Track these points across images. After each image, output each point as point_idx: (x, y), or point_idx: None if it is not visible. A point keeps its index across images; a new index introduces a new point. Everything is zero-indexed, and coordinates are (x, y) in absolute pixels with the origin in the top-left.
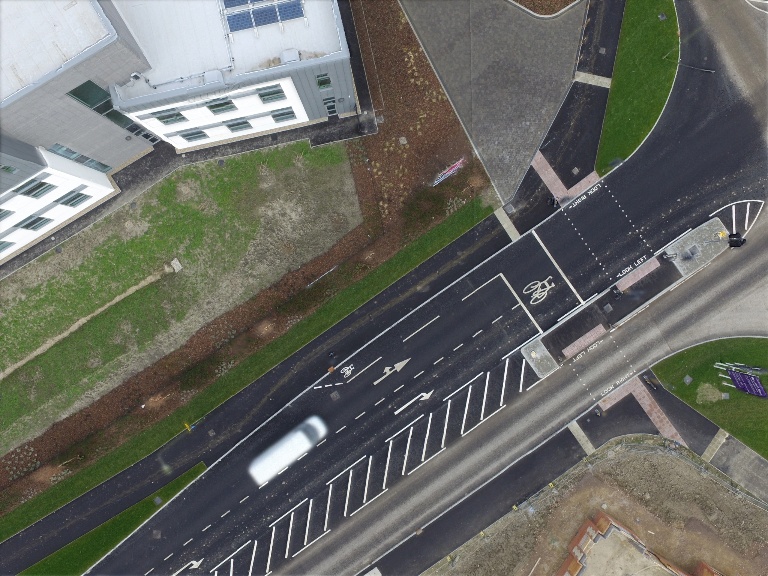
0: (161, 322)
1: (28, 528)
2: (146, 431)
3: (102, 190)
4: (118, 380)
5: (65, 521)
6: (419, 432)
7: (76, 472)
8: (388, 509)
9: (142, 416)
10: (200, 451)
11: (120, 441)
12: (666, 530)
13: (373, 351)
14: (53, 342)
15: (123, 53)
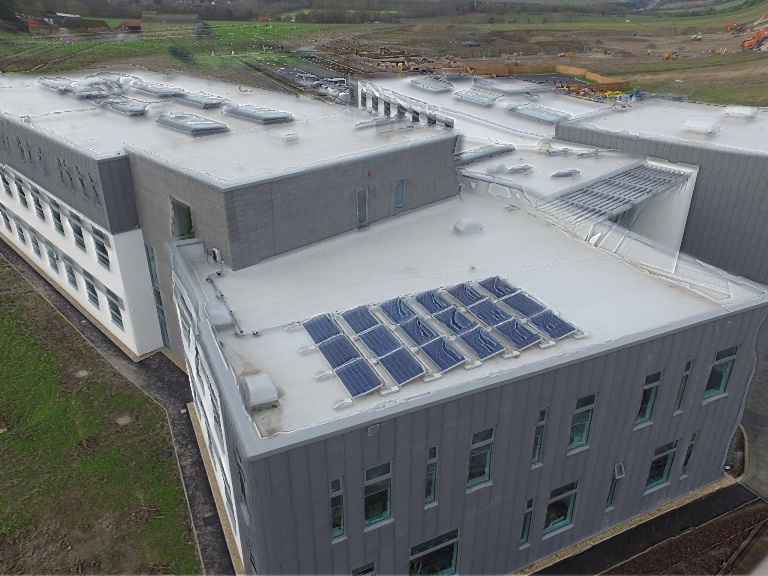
0: None
1: None
2: None
3: None
4: None
5: None
6: None
7: None
8: None
9: None
10: None
11: None
12: None
13: None
14: None
15: (223, 215)
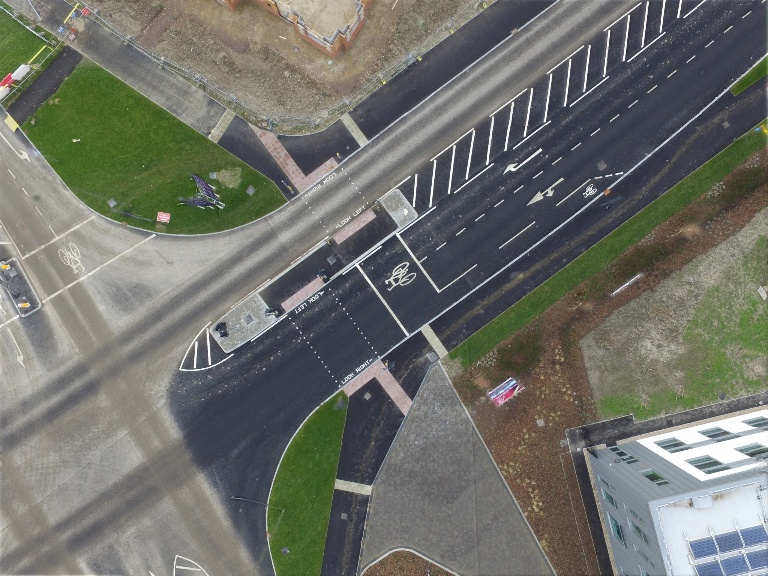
0: None
1: None
2: None
3: None
4: None
5: None
6: (517, 132)
7: None
8: (546, 54)
9: None
10: (737, 106)
11: None
12: (268, 41)
13: (565, 211)
14: None
15: None
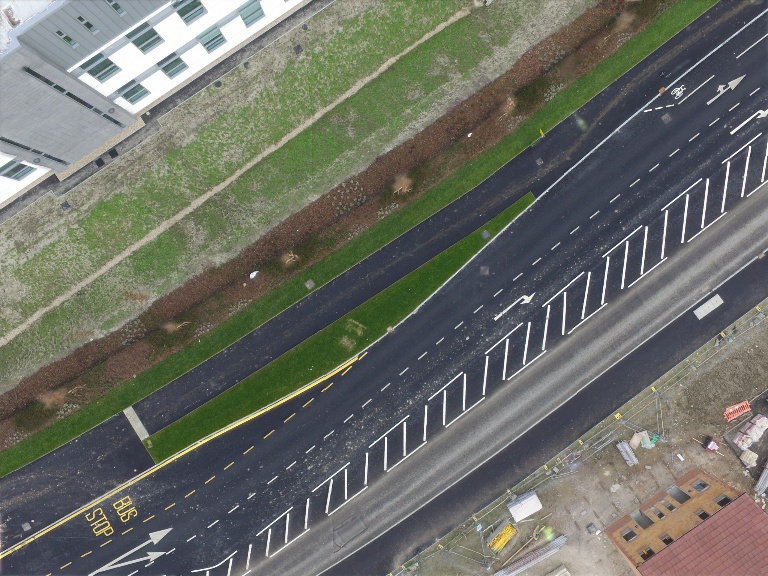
0: (481, 50)
1: (355, 266)
2: (472, 162)
3: None
4: (442, 110)
5: (392, 258)
6: (758, 151)
7: (402, 207)
8: (727, 234)
9: (471, 143)
10: (528, 181)
11: (446, 173)
12: None
13: (705, 70)
14: (362, 84)
15: None
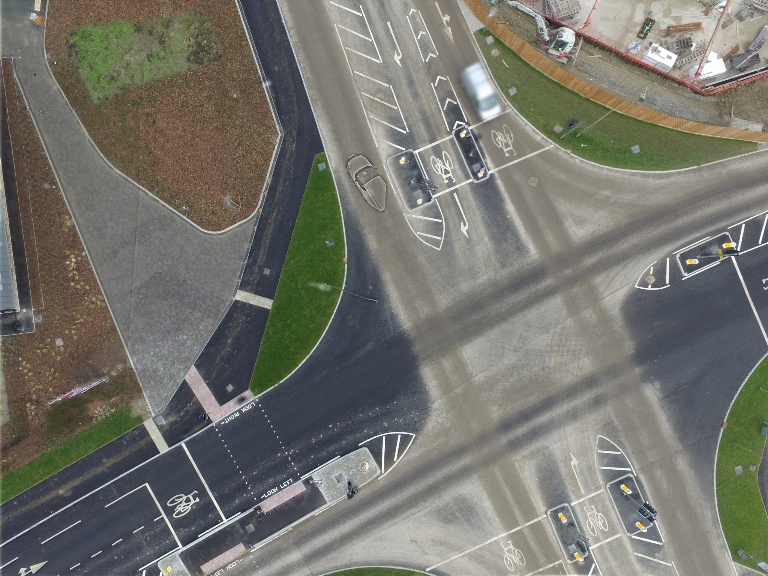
0: None
1: None
2: None
3: None
4: None
5: None
6: None
7: None
8: None
9: None
10: None
11: None
12: None
13: (10, 551)
14: None
15: None
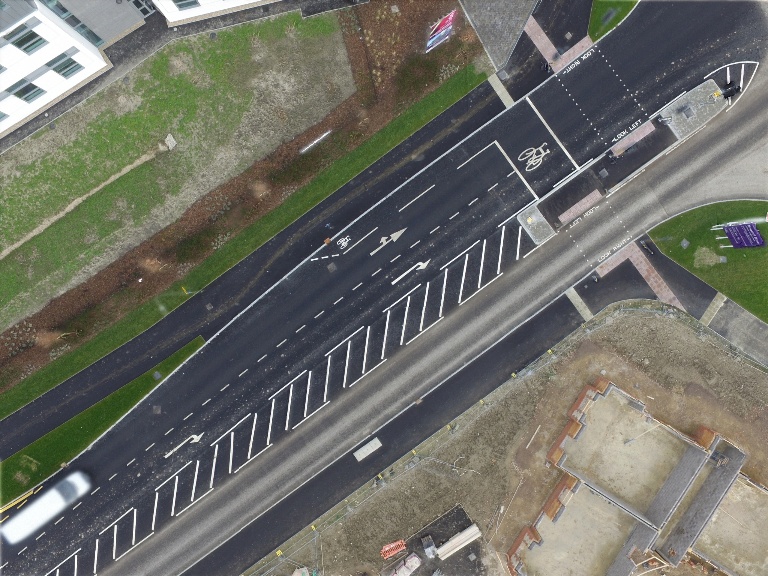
0: (156, 197)
1: (28, 405)
2: (144, 306)
3: (94, 61)
4: (115, 255)
5: (65, 397)
6: (417, 301)
7: (75, 348)
8: (387, 379)
9: (139, 289)
10: (198, 325)
11: (118, 316)
12: (666, 395)
13: (369, 222)
14: (49, 223)
15: None
